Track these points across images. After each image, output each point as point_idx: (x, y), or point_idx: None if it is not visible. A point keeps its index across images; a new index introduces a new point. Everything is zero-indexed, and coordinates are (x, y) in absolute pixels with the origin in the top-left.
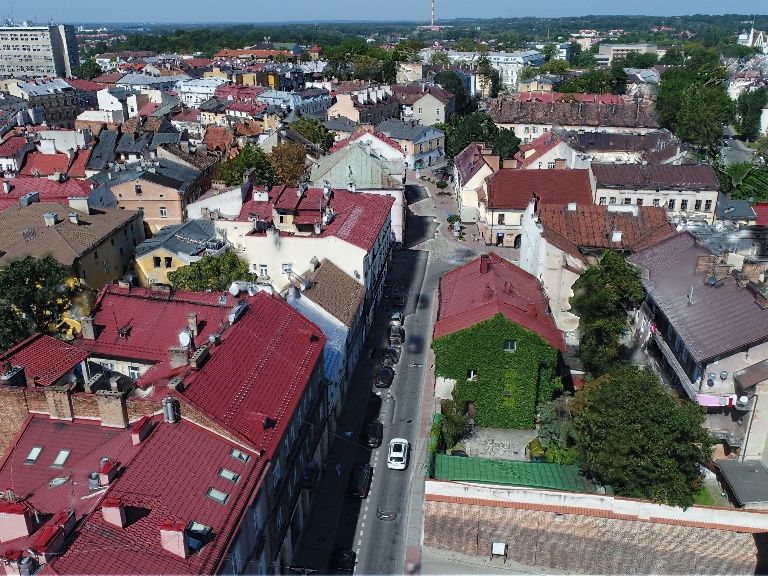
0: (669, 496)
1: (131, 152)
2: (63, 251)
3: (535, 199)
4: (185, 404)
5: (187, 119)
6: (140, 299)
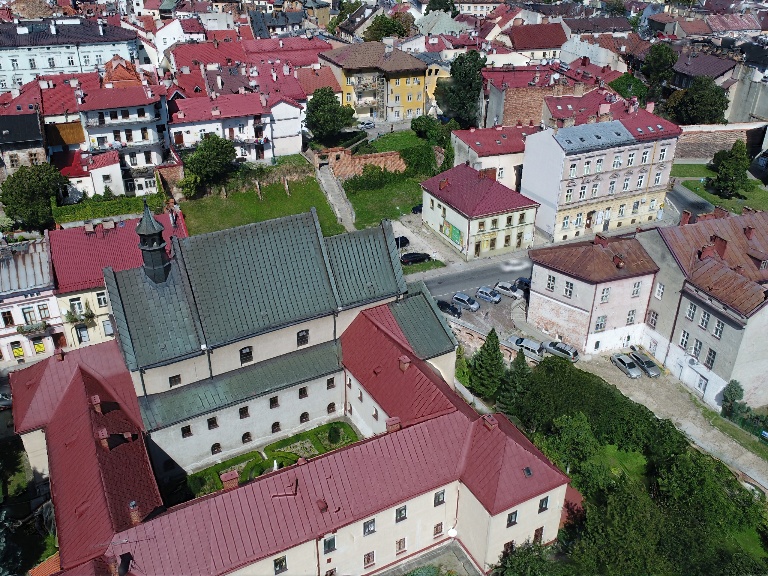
0: (721, 121)
1: (279, 26)
2: (417, 62)
3: (580, 32)
4: (605, 84)
5: (197, 10)
6: (500, 72)
